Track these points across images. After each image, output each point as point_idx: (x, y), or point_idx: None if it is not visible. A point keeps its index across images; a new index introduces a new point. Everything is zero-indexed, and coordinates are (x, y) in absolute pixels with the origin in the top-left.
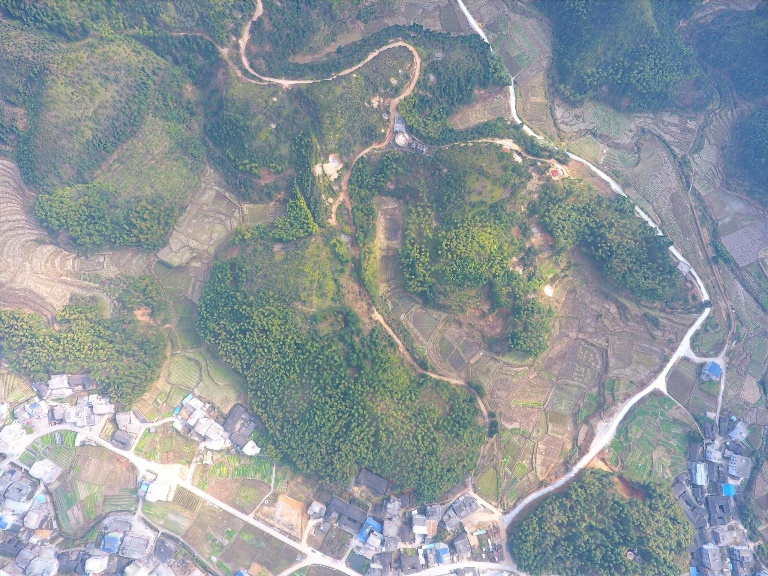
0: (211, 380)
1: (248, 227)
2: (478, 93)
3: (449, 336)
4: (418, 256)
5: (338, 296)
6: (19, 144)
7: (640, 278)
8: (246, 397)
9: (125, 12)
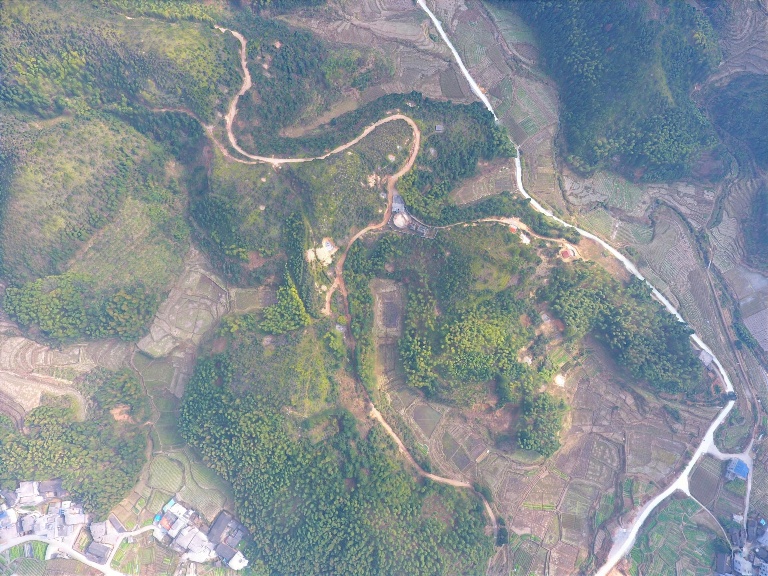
0: (195, 483)
1: (235, 317)
2: (482, 165)
3: (453, 432)
4: (419, 349)
5: (332, 396)
6: None
7: (659, 370)
8: (233, 503)
9: (103, 87)
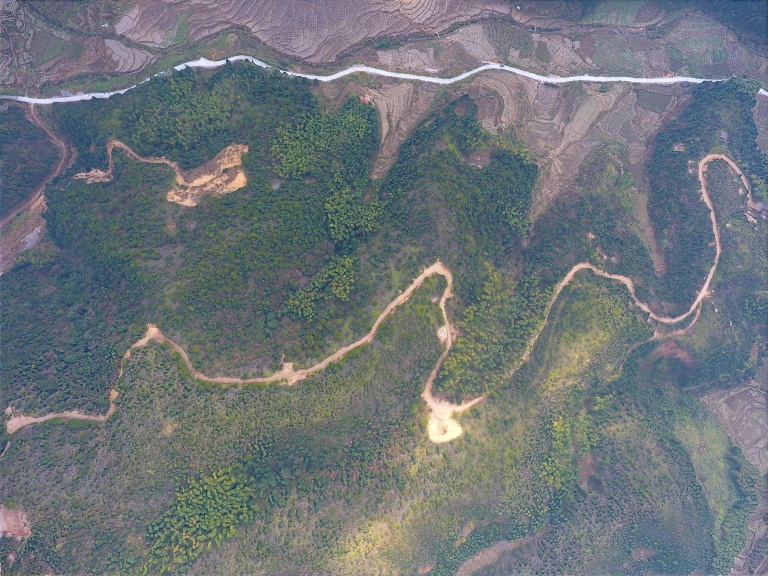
0: None
1: None
2: None
3: None
4: None
5: None
6: (658, 567)
7: None
8: None
9: (571, 413)
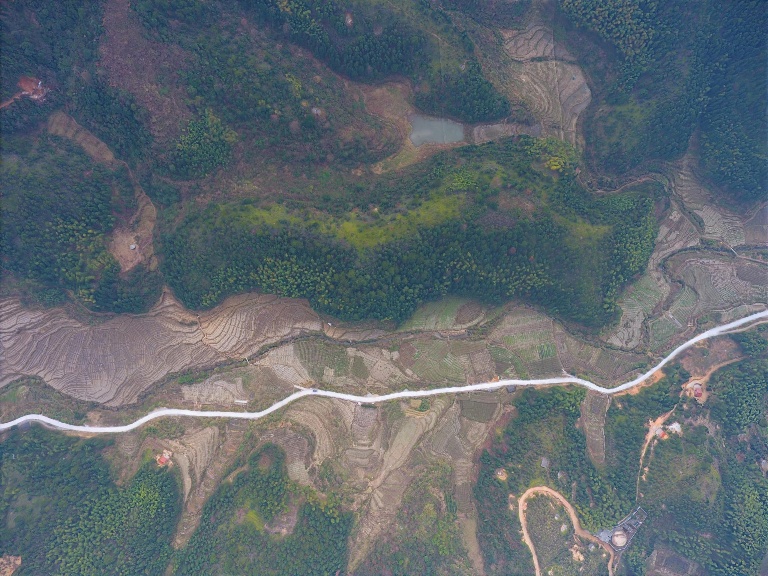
0: None
1: None
2: (579, 424)
3: None
4: (736, 569)
5: None
6: None
7: None
8: None
9: None
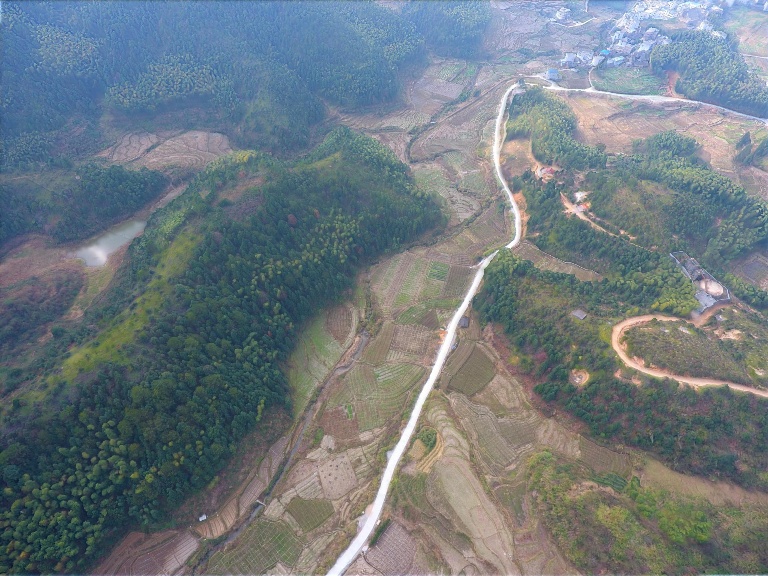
0: None
1: None
2: None
3: None
4: (766, 213)
5: None
6: None
7: None
8: None
9: None
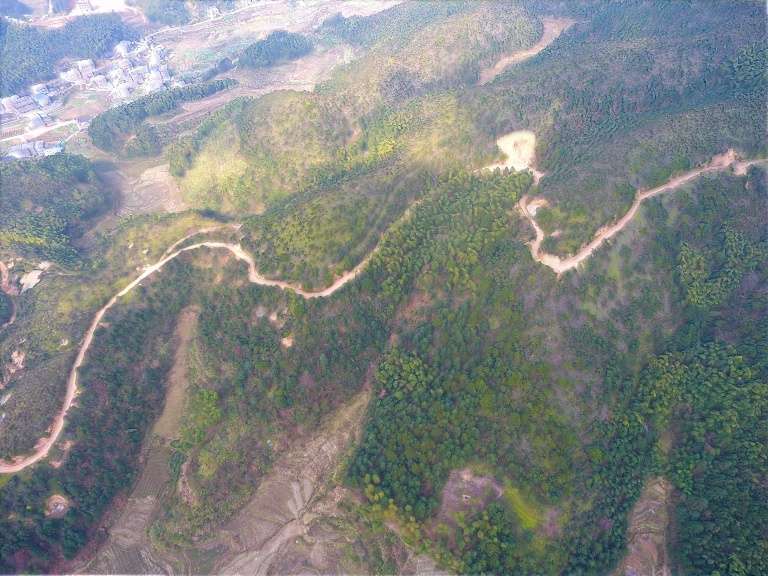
0: None
1: (91, 204)
2: None
3: None
4: None
5: None
6: None
7: None
8: None
9: None
